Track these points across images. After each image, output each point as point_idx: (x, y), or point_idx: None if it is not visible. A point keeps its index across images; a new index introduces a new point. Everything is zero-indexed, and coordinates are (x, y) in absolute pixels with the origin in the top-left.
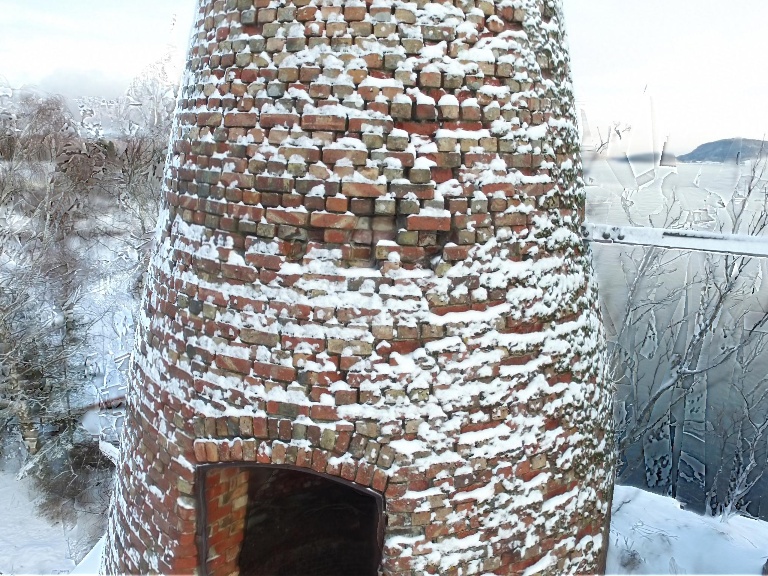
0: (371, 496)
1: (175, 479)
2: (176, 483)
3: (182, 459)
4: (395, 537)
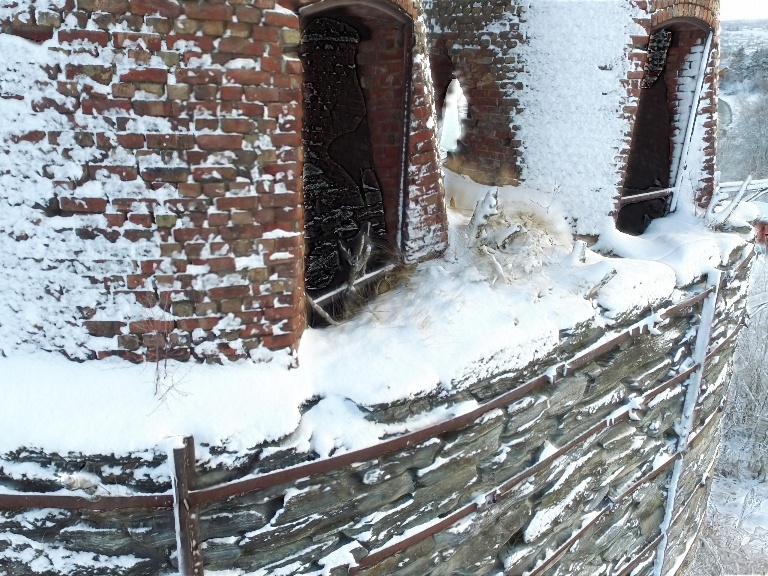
0: (401, 25)
1: (276, 33)
2: (278, 38)
3: (280, 7)
4: (418, 55)
